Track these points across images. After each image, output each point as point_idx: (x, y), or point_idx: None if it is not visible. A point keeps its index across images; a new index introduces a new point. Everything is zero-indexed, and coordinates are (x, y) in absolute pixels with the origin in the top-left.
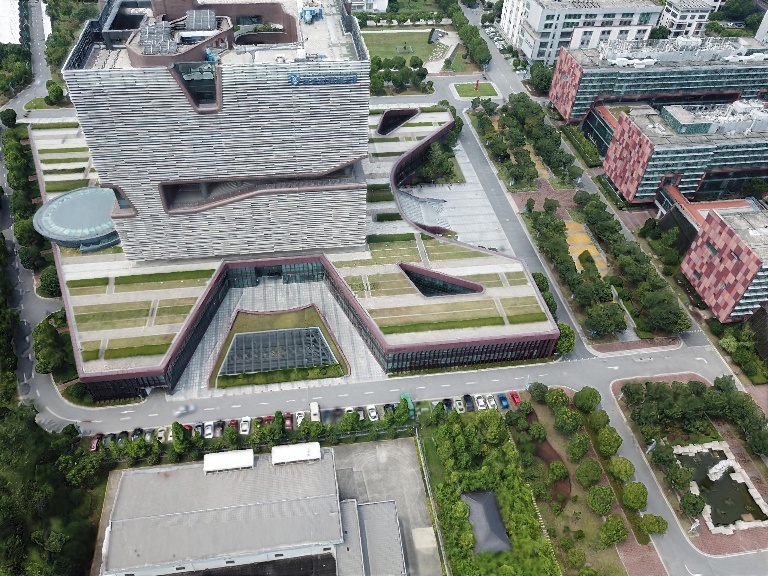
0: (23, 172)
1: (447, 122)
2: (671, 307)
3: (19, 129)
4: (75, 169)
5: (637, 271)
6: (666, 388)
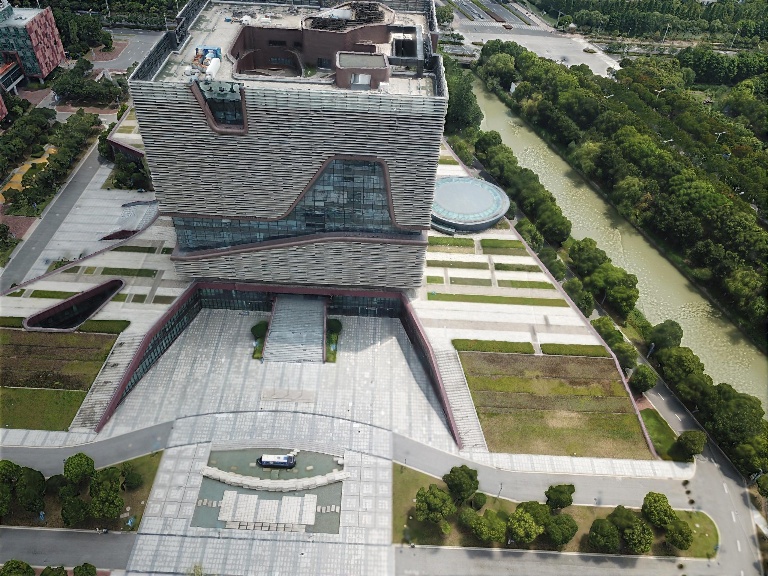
0: (576, 301)
1: (7, 294)
2: (37, 110)
3: (665, 435)
4: (506, 266)
5: (24, 131)
6: (99, 85)
